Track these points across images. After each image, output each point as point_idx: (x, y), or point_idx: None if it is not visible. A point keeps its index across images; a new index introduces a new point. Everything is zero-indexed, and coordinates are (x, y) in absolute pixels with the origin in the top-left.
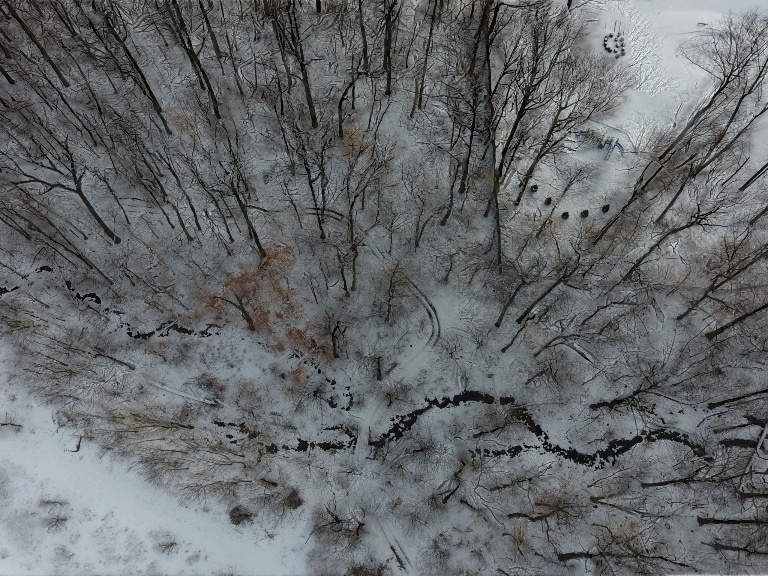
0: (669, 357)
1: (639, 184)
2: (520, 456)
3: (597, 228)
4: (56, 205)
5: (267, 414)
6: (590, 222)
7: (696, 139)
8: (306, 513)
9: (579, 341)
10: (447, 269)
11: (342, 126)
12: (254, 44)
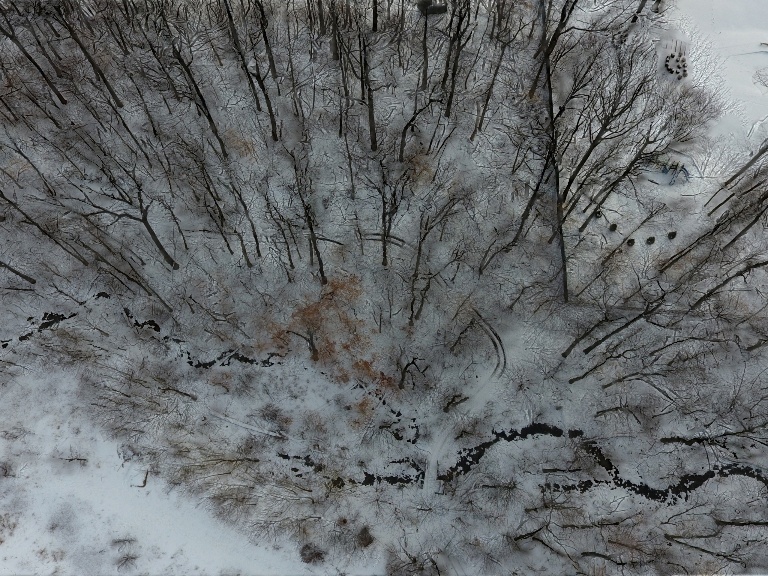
0: (740, 389)
1: (724, 218)
2: (591, 491)
3: (665, 256)
4: (119, 233)
5: (332, 447)
6: (657, 250)
7: (767, 165)
8: (378, 551)
9: None
10: (511, 297)
11: (403, 150)
12: (310, 64)
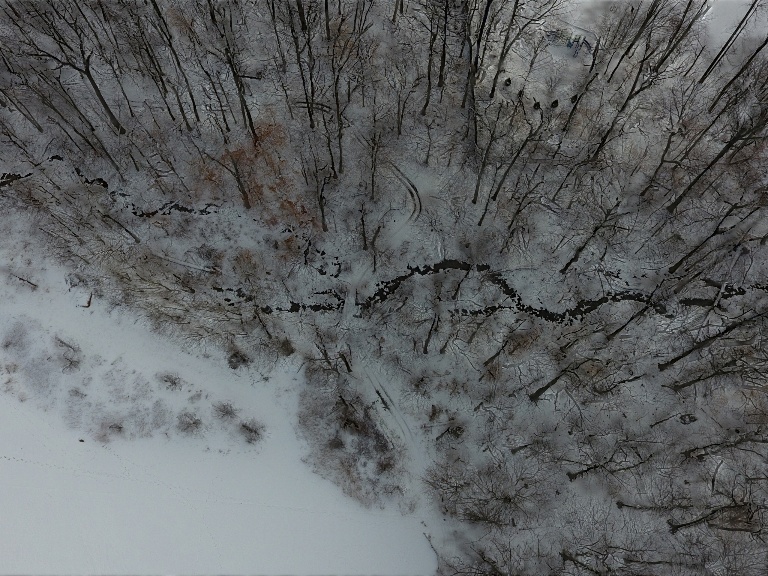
0: (633, 228)
1: (597, 50)
2: (495, 315)
3: (565, 113)
4: (66, 89)
5: (262, 280)
6: (559, 110)
7: (656, 31)
8: (298, 359)
9: (550, 215)
10: (427, 154)
11: (329, 26)
12: None
